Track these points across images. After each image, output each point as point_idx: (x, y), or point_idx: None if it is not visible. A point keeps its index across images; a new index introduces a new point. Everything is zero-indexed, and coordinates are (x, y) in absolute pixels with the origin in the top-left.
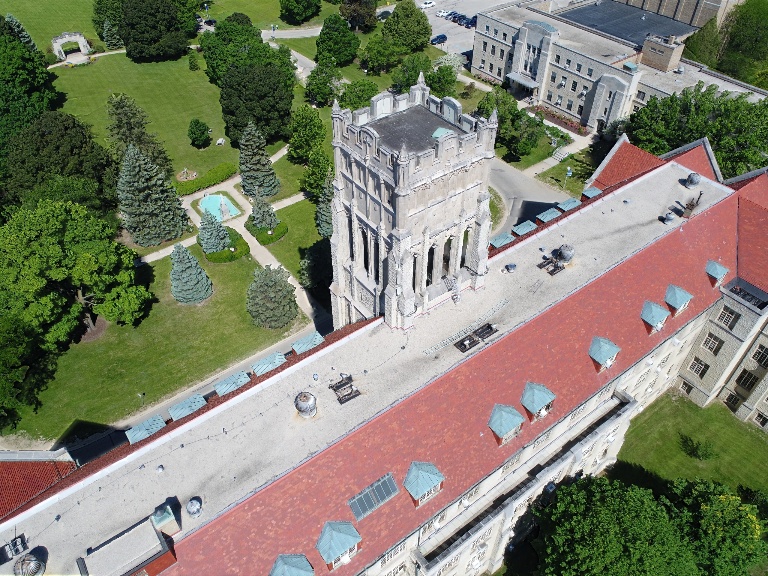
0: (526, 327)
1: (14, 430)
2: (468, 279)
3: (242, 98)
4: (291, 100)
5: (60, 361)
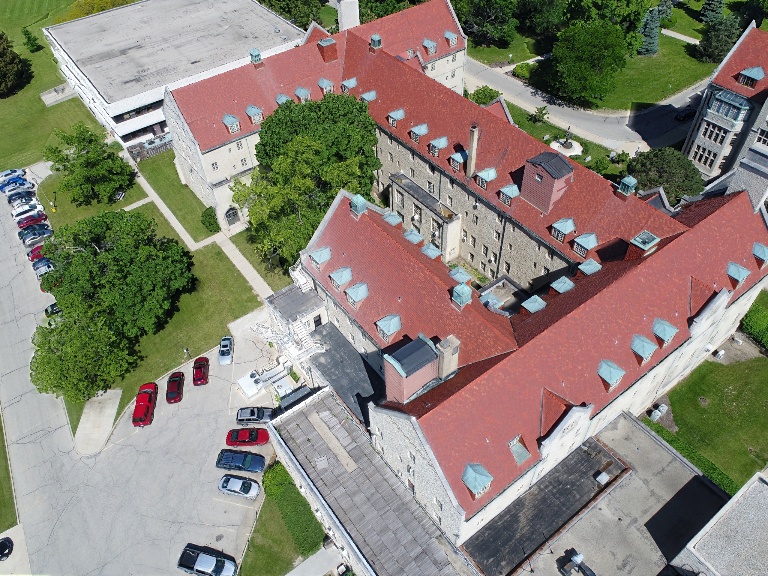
0: None
1: (599, 107)
2: None
3: None
4: None
5: None
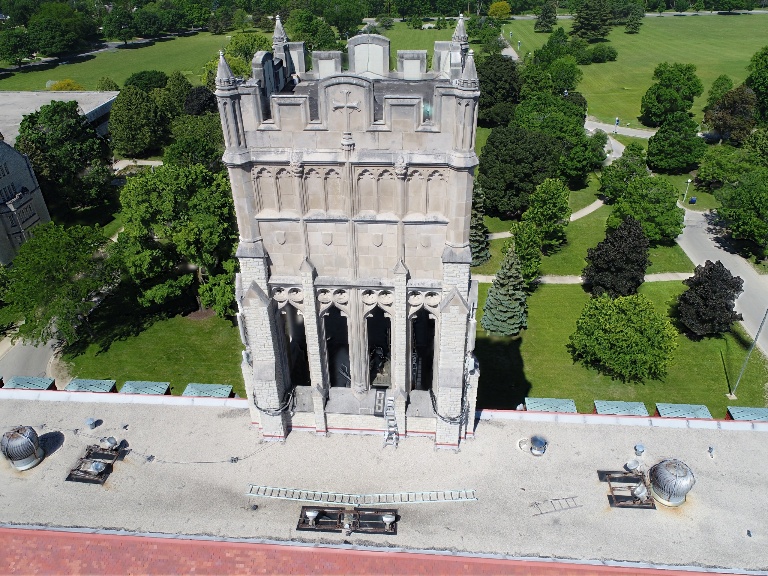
0: (446, 563)
1: (70, 359)
2: (427, 416)
3: (499, 158)
4: (578, 188)
5: (157, 324)
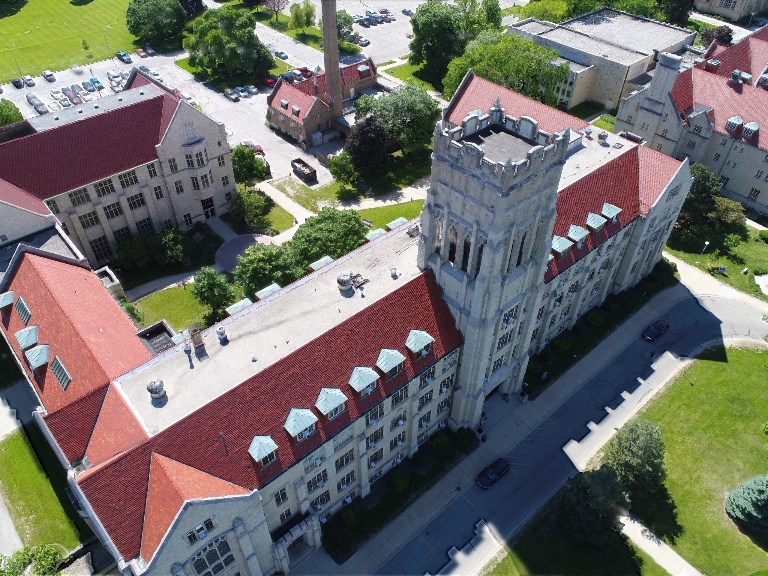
0: None
1: (767, 353)
2: None
3: None
4: None
5: None
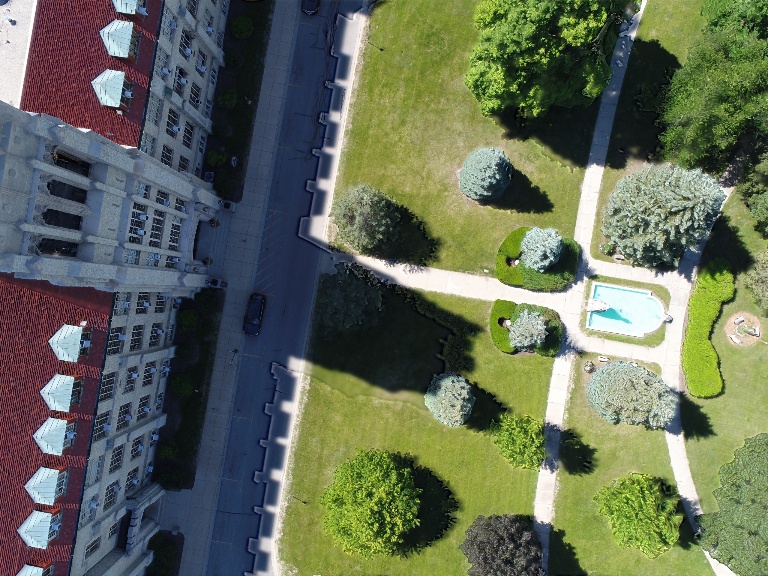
0: None
1: None
2: None
3: None
4: None
5: None
